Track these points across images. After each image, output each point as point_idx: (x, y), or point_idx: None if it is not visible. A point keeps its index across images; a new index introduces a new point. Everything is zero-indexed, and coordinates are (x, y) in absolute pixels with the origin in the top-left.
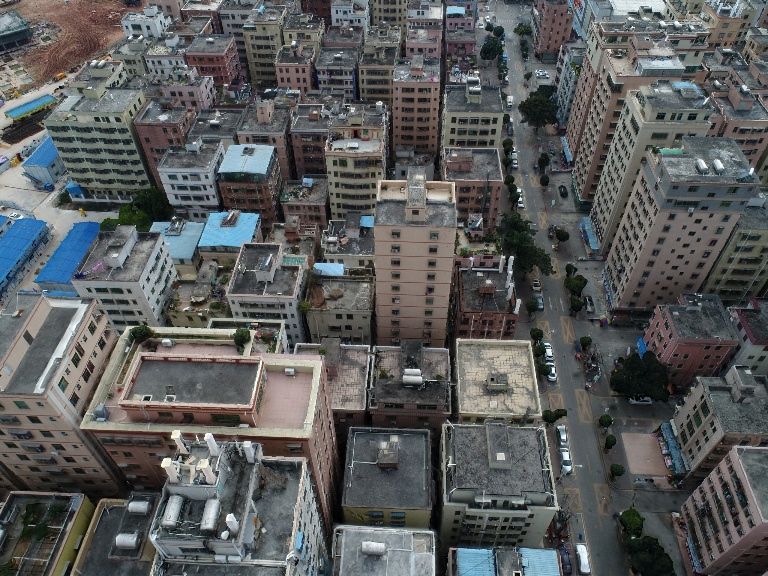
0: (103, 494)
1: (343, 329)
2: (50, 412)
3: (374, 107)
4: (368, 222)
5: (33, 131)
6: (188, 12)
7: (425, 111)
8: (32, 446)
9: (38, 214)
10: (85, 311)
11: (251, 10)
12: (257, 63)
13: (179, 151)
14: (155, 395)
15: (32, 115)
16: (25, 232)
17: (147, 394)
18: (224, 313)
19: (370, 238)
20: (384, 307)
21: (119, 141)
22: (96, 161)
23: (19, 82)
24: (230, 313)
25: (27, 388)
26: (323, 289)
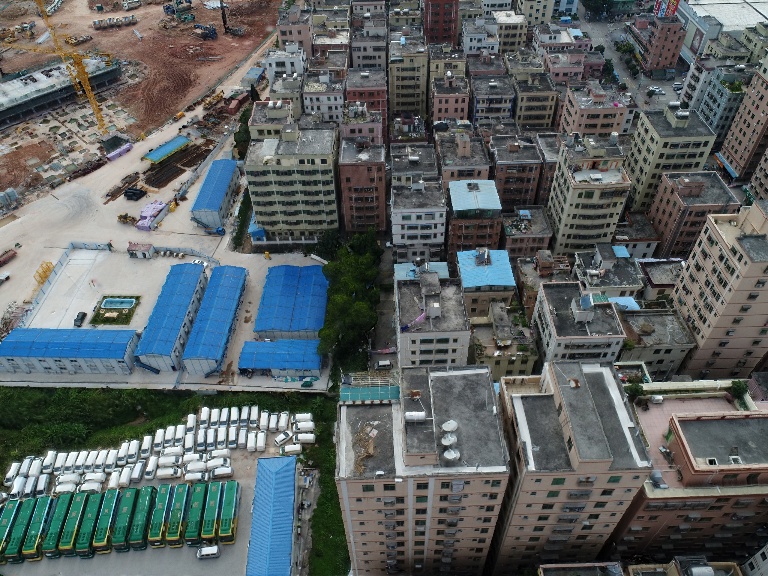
0: (584, 558)
1: (654, 363)
2: (636, 484)
3: (567, 135)
4: (620, 252)
5: (176, 174)
6: (319, 46)
7: (605, 136)
8: (573, 518)
9: (220, 260)
10: (613, 375)
11: (385, 42)
12: (398, 94)
13: (403, 190)
14: (717, 457)
15: (167, 157)
16: (230, 280)
17: (708, 457)
18: (538, 355)
19: (623, 268)
20: (713, 340)
21: (318, 182)
22: (288, 203)
23: (123, 122)
24: (539, 355)
25: (627, 462)
26: (631, 325)
